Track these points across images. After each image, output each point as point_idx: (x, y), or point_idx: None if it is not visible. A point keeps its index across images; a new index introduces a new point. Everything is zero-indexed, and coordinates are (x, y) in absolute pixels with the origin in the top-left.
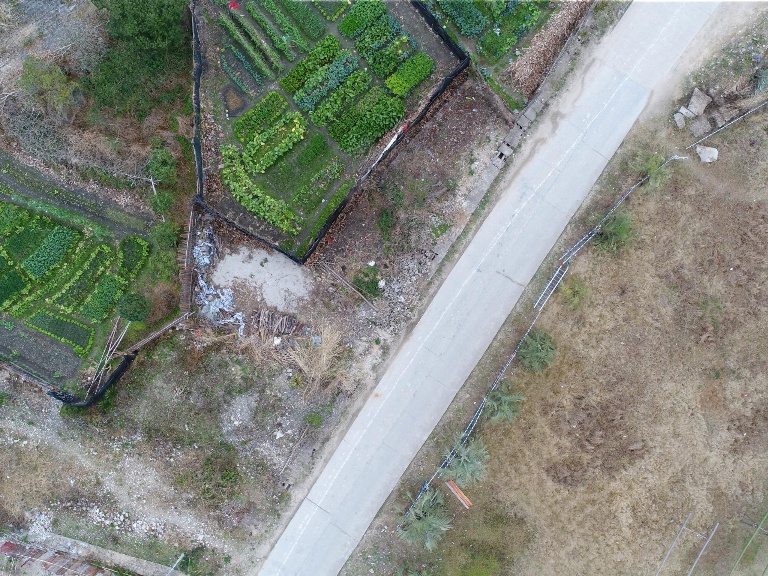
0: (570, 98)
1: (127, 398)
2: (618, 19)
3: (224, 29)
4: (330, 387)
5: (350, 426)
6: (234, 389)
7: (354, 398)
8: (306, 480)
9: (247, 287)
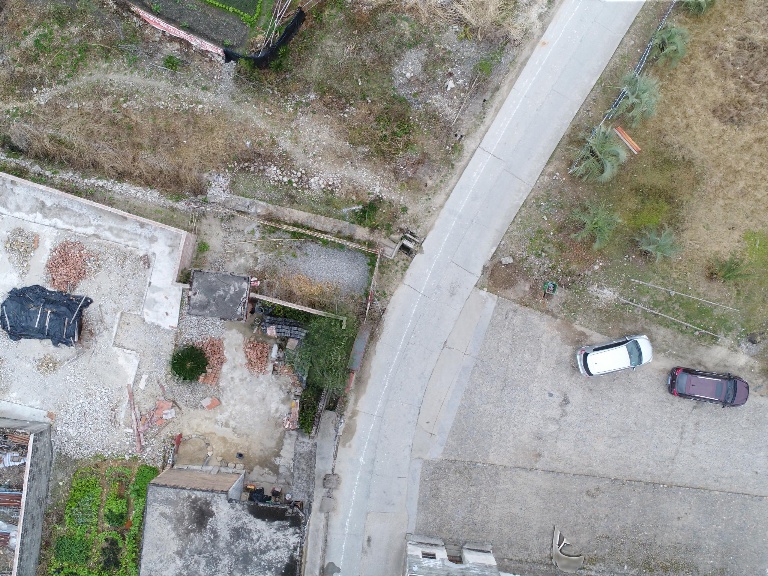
0: None
1: (298, 59)
2: None
3: None
4: None
5: (519, 75)
6: (404, 44)
7: (522, 47)
8: (478, 130)
9: None
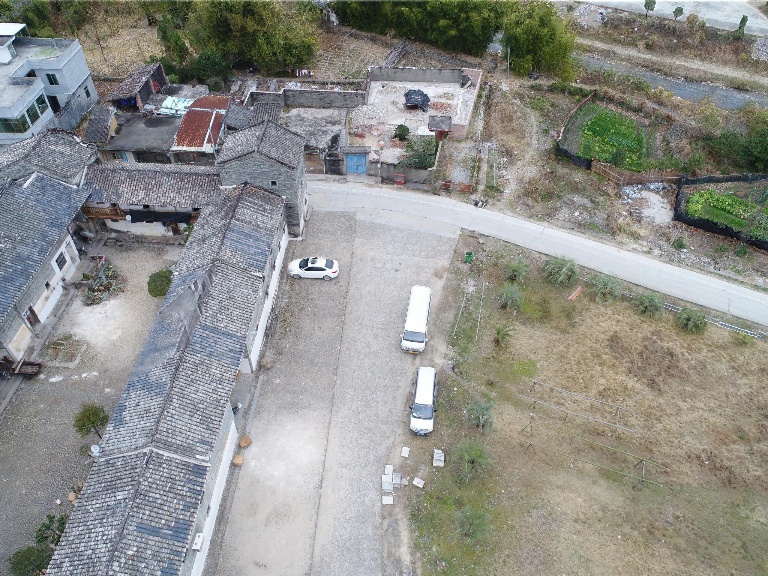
0: None
1: (566, 166)
2: None
3: None
4: None
5: (595, 241)
6: None
7: (612, 242)
8: (555, 227)
9: (647, 203)
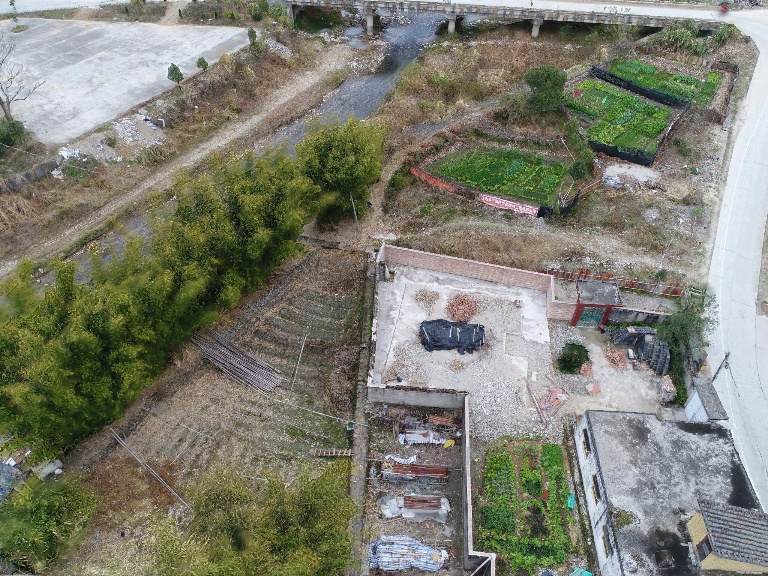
0: (743, 115)
1: None
2: (745, 96)
3: (567, 107)
4: None
5: (719, 217)
6: (643, 206)
7: (713, 207)
8: (709, 240)
9: (625, 176)
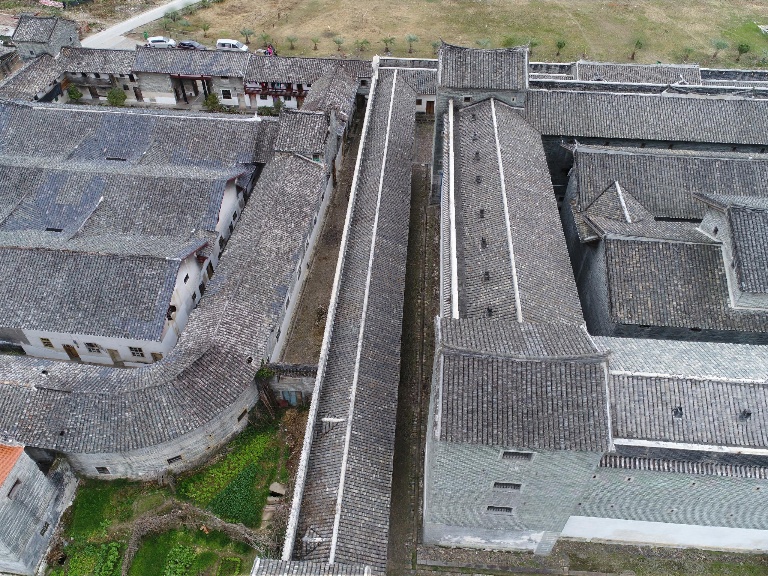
0: None
1: None
2: None
3: None
4: (152, 0)
5: (156, 8)
6: (122, 4)
7: None
8: None
9: None
